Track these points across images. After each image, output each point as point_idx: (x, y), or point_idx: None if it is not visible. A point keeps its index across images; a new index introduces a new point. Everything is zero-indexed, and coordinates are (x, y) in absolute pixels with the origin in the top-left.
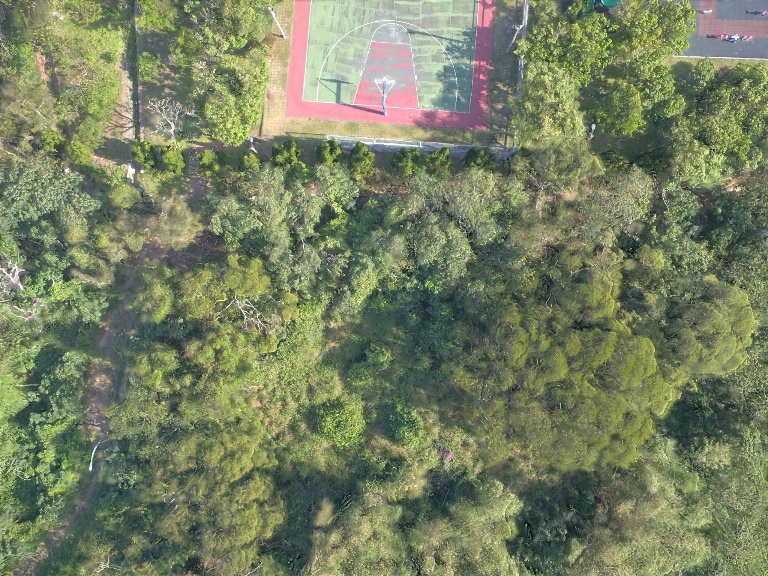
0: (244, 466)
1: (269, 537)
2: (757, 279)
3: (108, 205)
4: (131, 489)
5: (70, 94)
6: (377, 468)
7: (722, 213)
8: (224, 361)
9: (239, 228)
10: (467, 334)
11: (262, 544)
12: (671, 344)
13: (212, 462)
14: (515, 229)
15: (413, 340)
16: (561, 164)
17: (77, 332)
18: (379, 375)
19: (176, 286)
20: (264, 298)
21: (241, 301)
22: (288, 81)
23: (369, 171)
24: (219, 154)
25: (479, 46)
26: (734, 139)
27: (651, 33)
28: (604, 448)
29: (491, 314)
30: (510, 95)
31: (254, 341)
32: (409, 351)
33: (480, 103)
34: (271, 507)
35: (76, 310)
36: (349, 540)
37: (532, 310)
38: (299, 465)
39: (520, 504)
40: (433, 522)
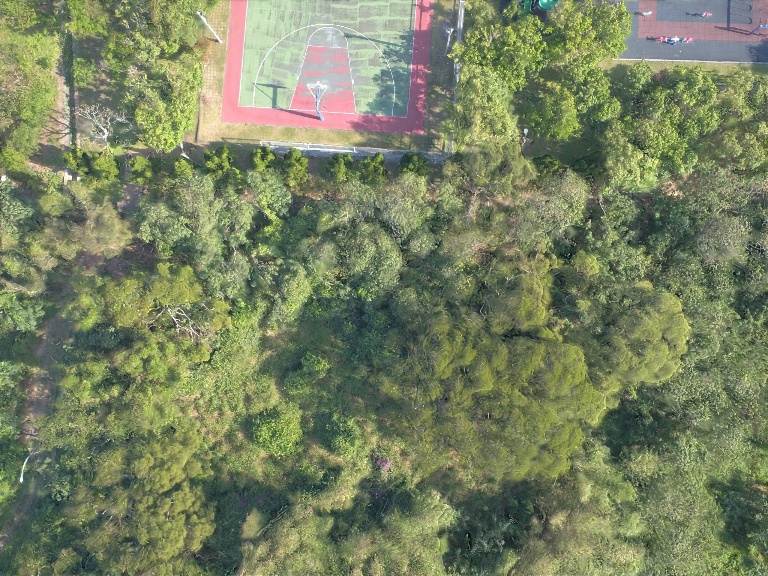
0: (174, 477)
1: (203, 549)
2: (694, 285)
3: (44, 212)
4: (65, 500)
5: (3, 100)
6: (314, 478)
7: (660, 218)
8: (152, 371)
9: (168, 236)
10: (404, 342)
11: (196, 556)
12: (603, 352)
13: (141, 473)
14: (448, 235)
15: (351, 348)
16: (493, 169)
17: (14, 341)
18: (317, 383)
19: (107, 294)
20: (196, 306)
21: (173, 309)
22: (224, 86)
23: (302, 177)
24: (153, 160)
25: (417, 50)
26: (669, 143)
27: (585, 36)
28: (533, 458)
29: (423, 322)
30: (448, 99)
31: (185, 350)
32: (346, 359)
33: (418, 107)
34: (201, 519)
35: (10, 319)
36: (275, 553)
37: (462, 318)
38: (236, 475)
39: (457, 514)
40: (365, 534)
